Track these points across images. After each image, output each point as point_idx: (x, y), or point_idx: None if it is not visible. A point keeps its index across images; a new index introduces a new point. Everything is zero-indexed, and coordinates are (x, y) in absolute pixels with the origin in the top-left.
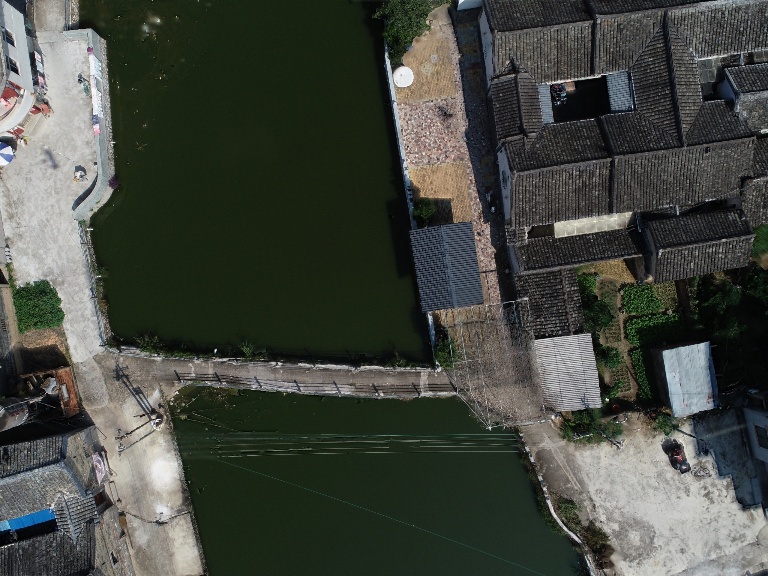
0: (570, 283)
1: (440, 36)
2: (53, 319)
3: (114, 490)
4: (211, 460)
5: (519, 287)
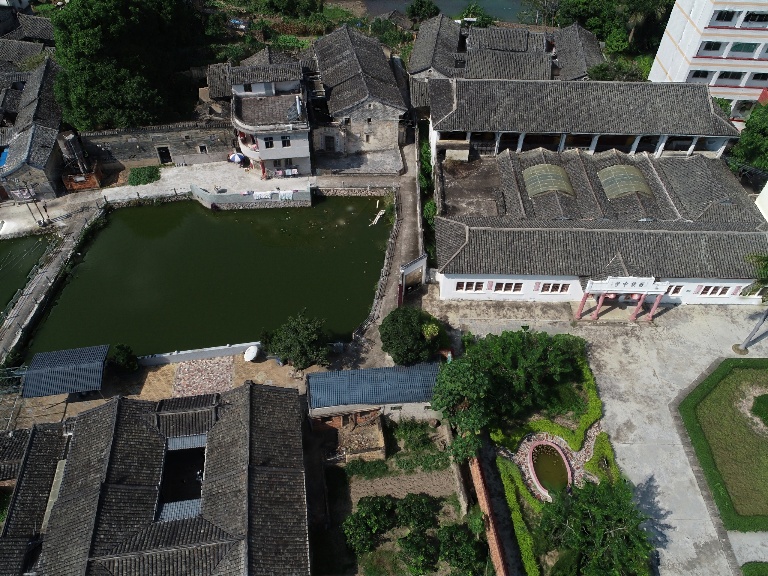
0: (5, 470)
1: (288, 386)
2: (133, 180)
3: (8, 205)
4: (2, 253)
5: (25, 431)
